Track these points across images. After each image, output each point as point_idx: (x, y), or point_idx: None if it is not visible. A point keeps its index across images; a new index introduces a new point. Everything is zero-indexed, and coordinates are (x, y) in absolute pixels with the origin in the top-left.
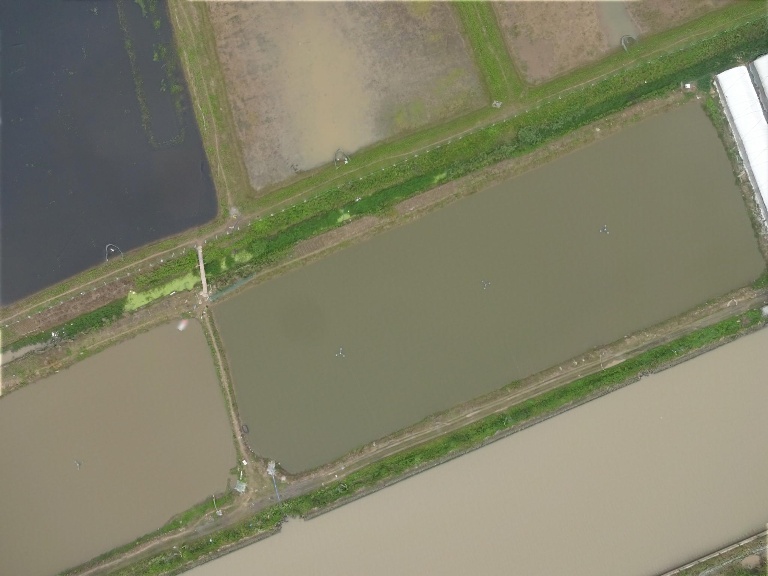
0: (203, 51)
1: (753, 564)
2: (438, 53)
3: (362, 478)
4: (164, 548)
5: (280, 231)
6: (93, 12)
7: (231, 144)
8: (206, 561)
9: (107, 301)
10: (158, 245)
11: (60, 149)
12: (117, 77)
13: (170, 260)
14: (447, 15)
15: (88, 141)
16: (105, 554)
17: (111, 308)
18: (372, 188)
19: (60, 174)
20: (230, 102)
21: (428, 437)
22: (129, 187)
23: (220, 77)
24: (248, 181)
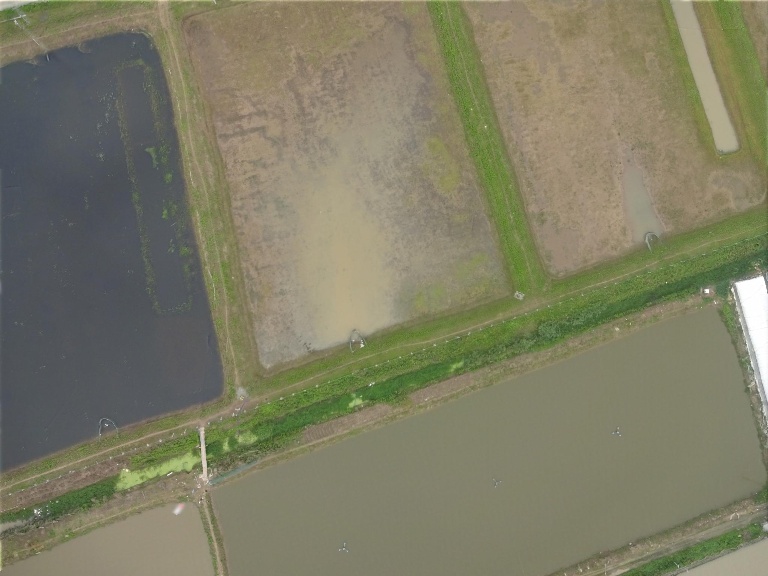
0: (217, 213)
1: None
2: (463, 235)
3: None
4: None
5: (288, 414)
6: (99, 158)
7: (242, 317)
8: None
9: (97, 479)
10: (157, 423)
11: (54, 308)
12: (121, 233)
13: (169, 441)
14: (474, 195)
15: (86, 301)
16: None
17: (101, 487)
18: (387, 374)
19: (53, 336)
20: (243, 270)
21: None
22: (128, 356)
23: (234, 242)
24: (257, 357)
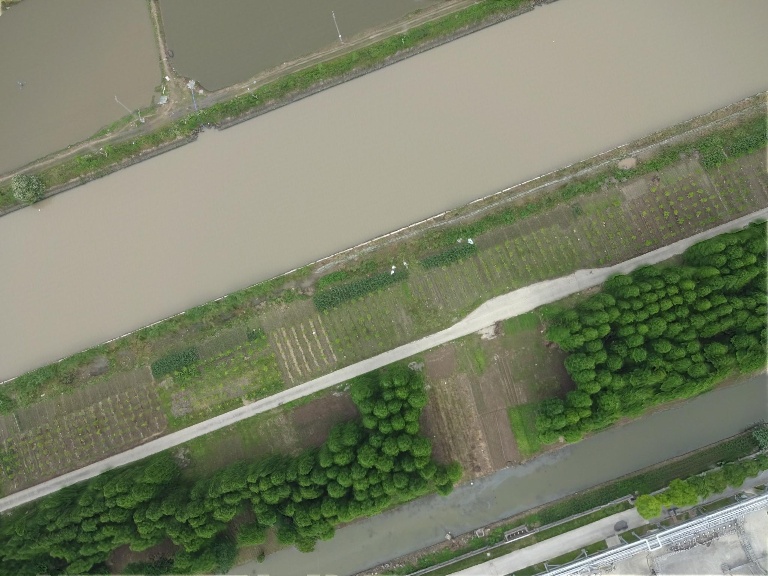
0: None
1: (629, 165)
2: None
3: (271, 89)
4: (92, 150)
5: None
6: None
7: None
8: (129, 165)
9: None
10: None
11: None
12: None
13: None
14: None
15: None
16: (41, 158)
17: None
18: None
19: None
20: None
21: (333, 56)
22: None
23: None
24: None
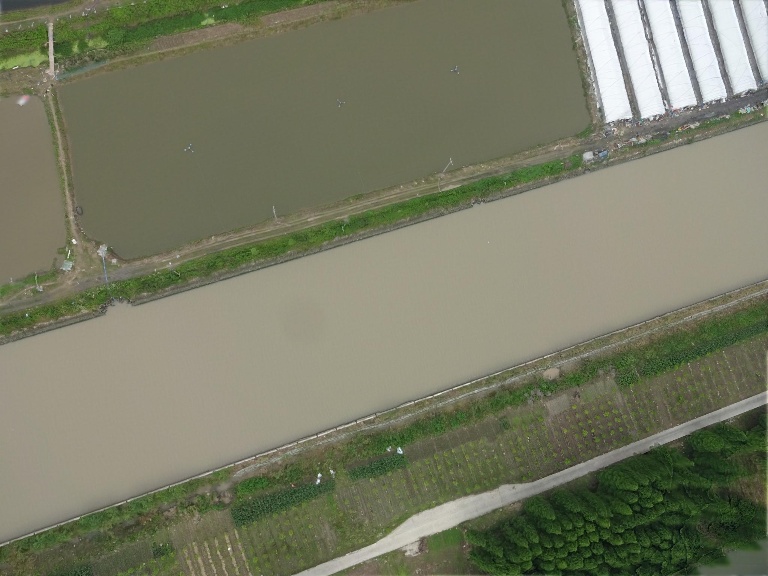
0: None
1: (553, 376)
2: None
3: (196, 267)
4: None
5: (140, 23)
6: None
7: None
8: (19, 338)
9: None
10: (4, 15)
11: None
12: None
13: (16, 31)
14: None
15: None
16: None
17: None
18: None
19: None
20: None
21: (268, 235)
22: None
23: None
24: None
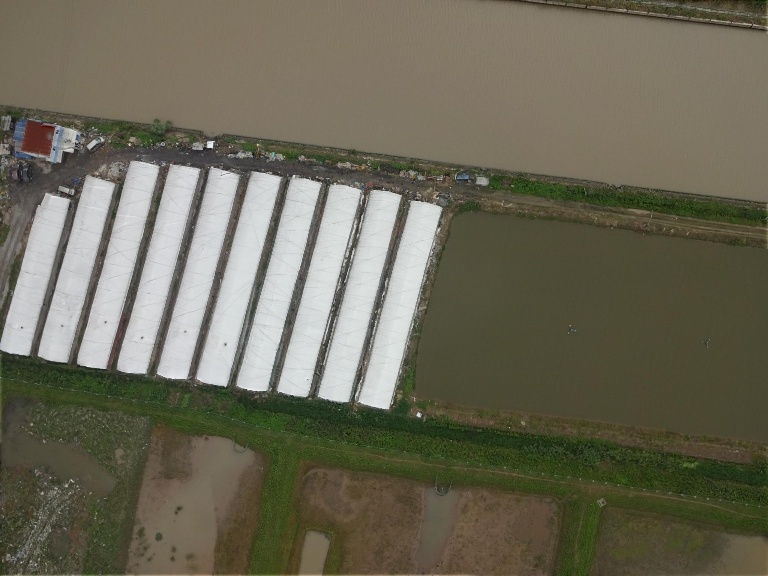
0: None
1: None
2: None
3: None
4: None
5: None
6: None
7: None
8: None
9: None
10: None
11: None
12: None
13: None
14: None
15: None
16: None
17: None
18: (763, 493)
19: None
20: None
21: None
22: None
23: None
24: None
